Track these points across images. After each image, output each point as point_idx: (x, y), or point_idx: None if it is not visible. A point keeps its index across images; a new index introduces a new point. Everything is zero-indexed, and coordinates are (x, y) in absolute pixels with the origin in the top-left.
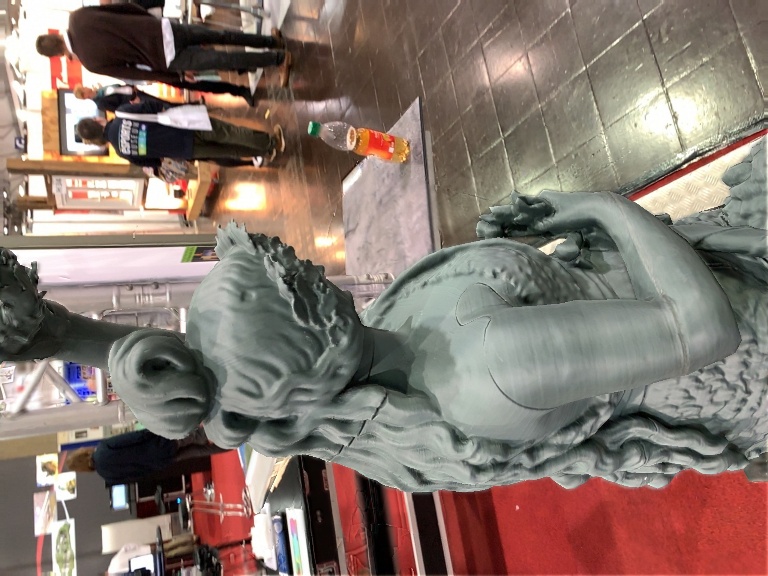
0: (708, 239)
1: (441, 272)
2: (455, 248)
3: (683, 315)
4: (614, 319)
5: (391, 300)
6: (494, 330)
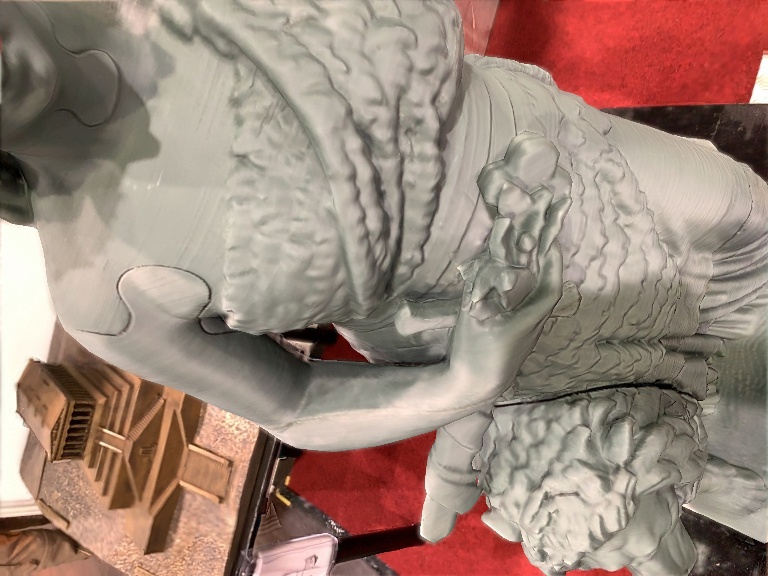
0: (444, 430)
1: (245, 207)
2: (334, 204)
3: (270, 431)
4: (220, 404)
5: (230, 51)
6: (100, 342)
